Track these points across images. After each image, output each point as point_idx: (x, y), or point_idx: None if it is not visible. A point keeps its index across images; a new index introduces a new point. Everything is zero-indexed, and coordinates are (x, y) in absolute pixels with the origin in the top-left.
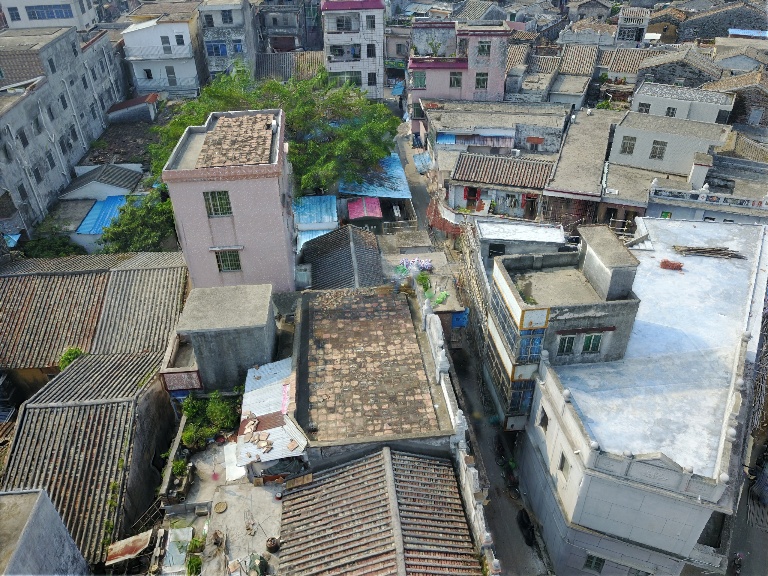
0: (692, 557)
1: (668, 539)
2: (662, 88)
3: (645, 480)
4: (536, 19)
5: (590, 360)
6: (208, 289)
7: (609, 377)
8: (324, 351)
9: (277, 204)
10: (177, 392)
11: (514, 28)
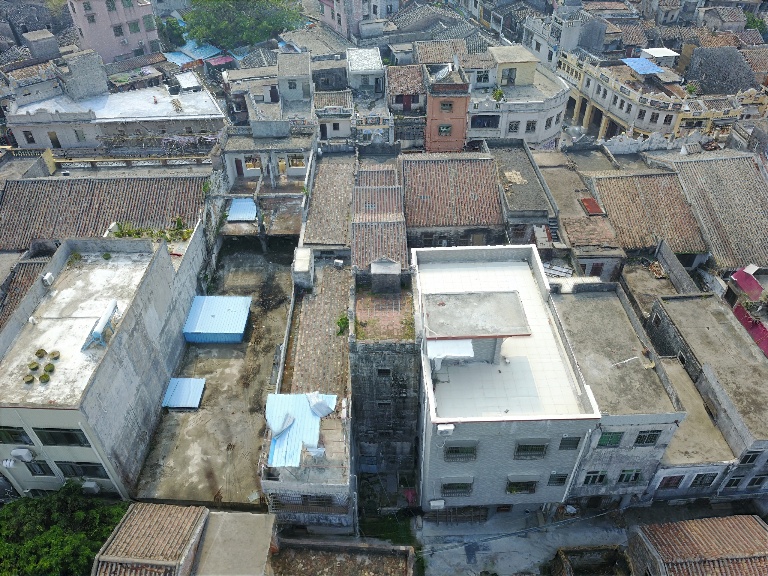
0: None
1: None
2: (371, 53)
3: None
4: (581, 6)
5: (69, 96)
6: (46, 30)
7: None
8: None
9: (80, 13)
10: None
11: None
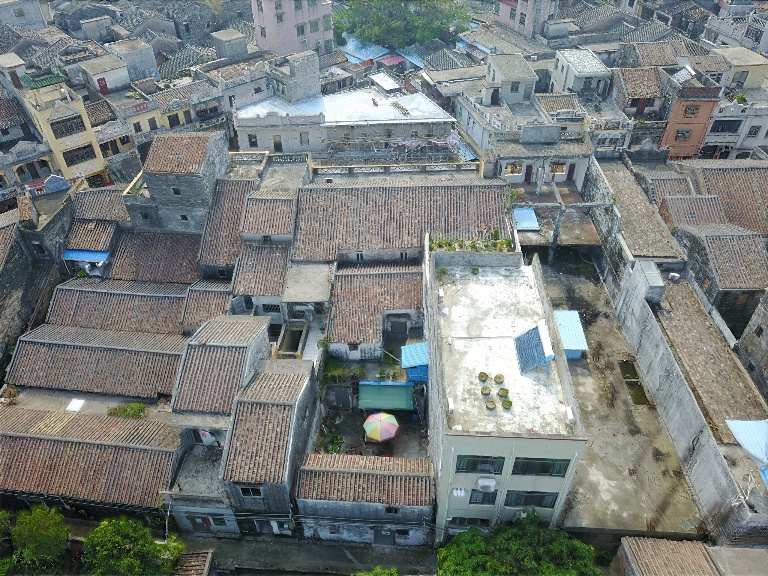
0: None
1: None
2: (586, 55)
3: None
4: (753, 5)
5: (284, 98)
6: None
7: (281, 105)
8: None
9: (271, 12)
10: None
11: (723, 8)
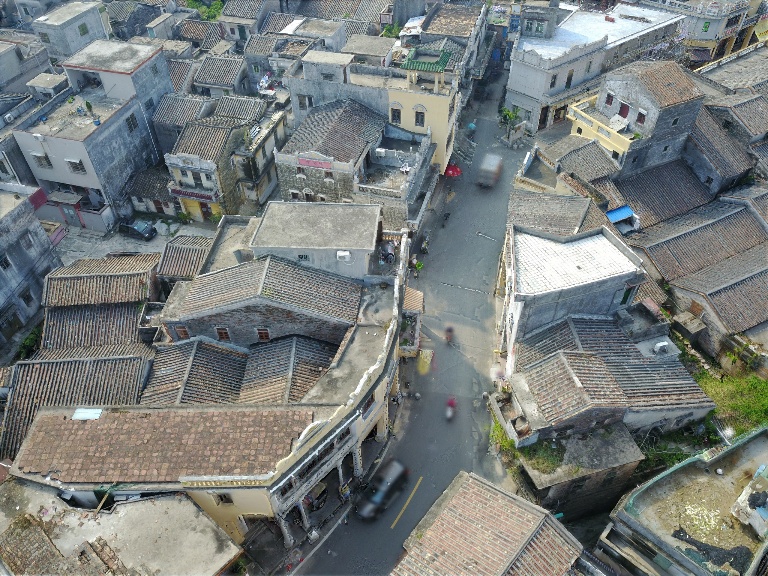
0: (542, 100)
1: (536, 92)
2: None
3: (528, 62)
4: None
5: (539, 36)
6: None
7: (543, 42)
8: (439, 18)
9: None
10: (384, 25)
11: None
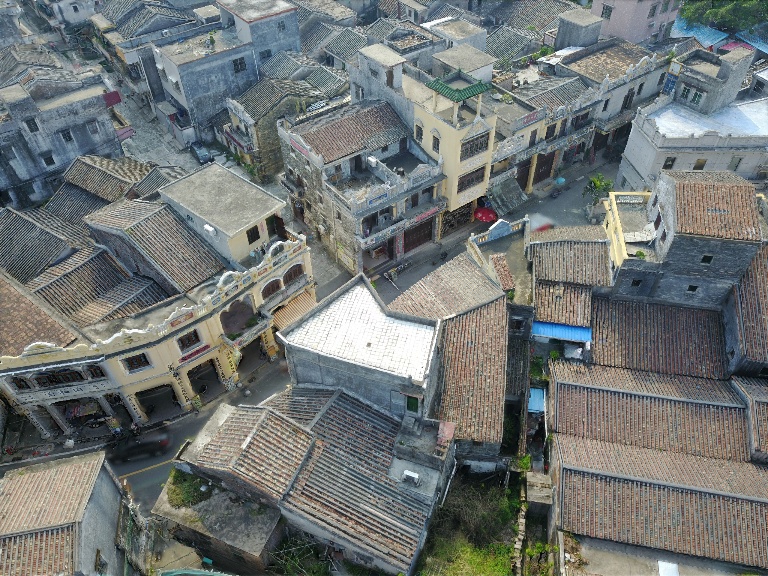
0: None
1: None
2: None
3: None
4: None
5: (693, 108)
6: None
7: (692, 117)
8: (602, 55)
9: None
10: None
11: None
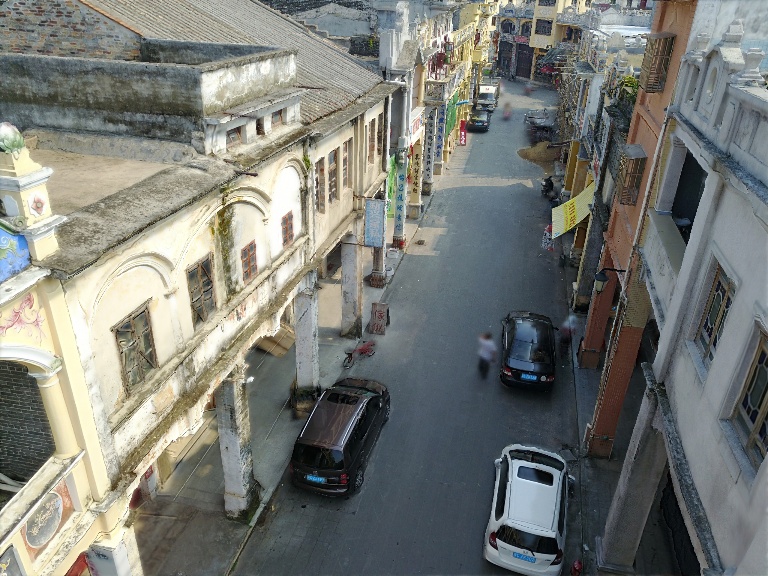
0: None
1: None
2: None
3: None
4: None
5: None
6: None
7: None
8: None
9: None
10: None
11: None
